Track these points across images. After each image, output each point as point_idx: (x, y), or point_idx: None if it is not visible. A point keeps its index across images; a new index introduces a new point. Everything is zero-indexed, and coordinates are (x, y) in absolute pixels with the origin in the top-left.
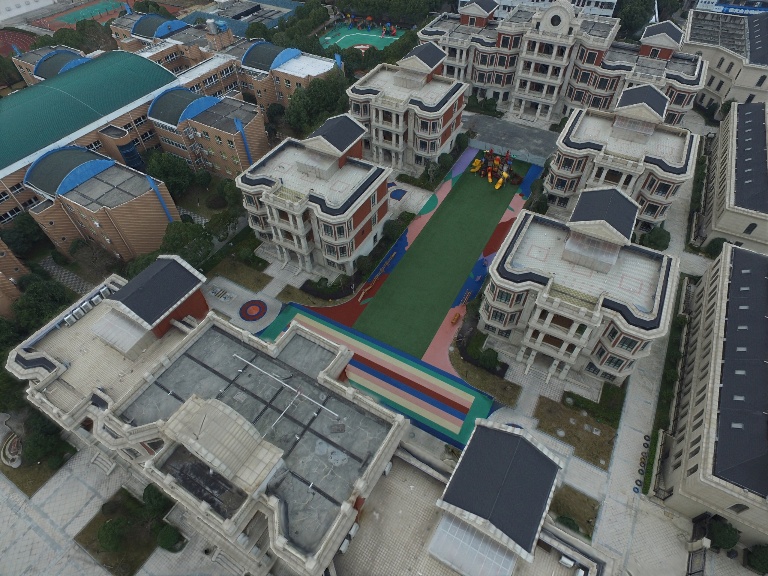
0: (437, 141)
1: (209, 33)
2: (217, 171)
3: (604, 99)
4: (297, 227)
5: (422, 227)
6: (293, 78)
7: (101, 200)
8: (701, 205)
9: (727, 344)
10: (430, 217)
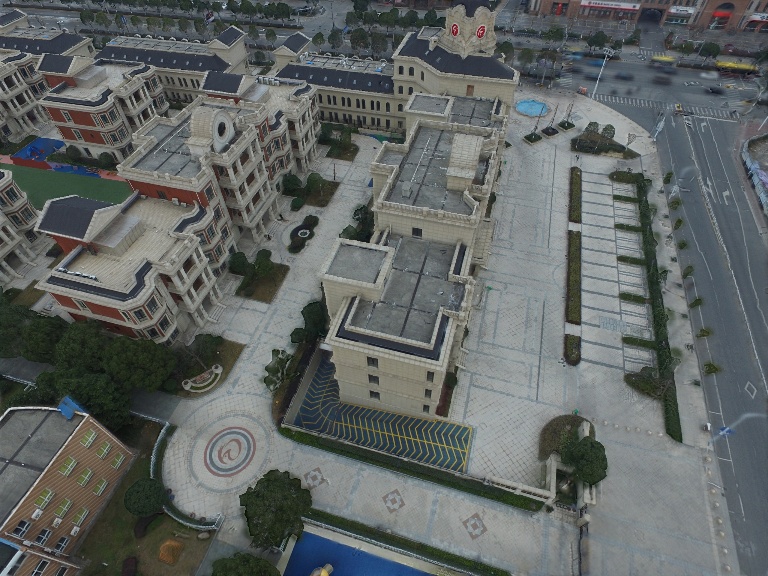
0: None
1: None
2: None
3: None
4: None
5: None
6: None
7: None
8: None
9: (158, 66)
10: None
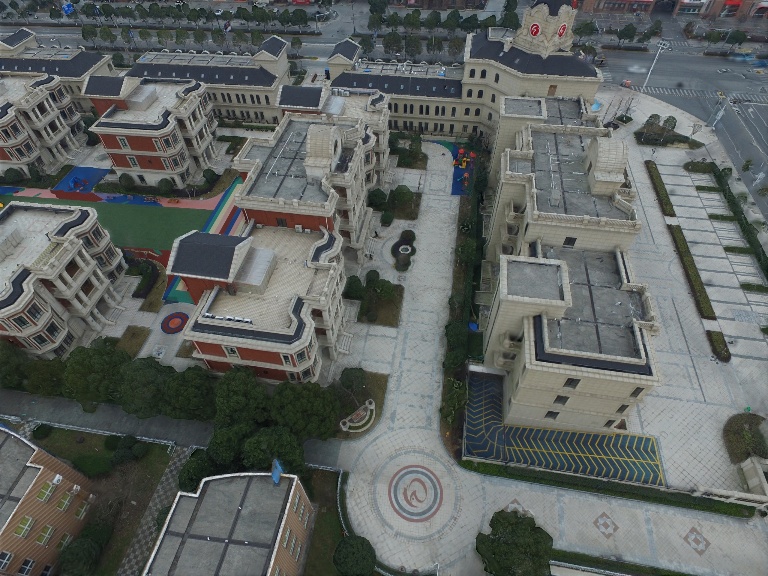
0: None
1: None
2: None
3: None
4: (87, 263)
5: None
6: None
7: (5, 488)
8: None
9: None
10: None
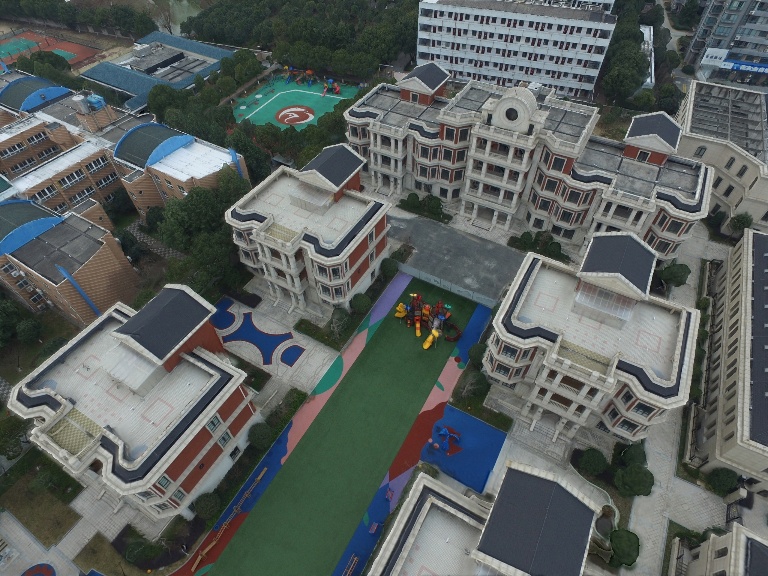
0: (344, 286)
1: (79, 112)
2: (61, 310)
3: (576, 214)
4: None
5: (312, 418)
6: (173, 180)
7: None
8: (701, 392)
9: None
10: (327, 399)
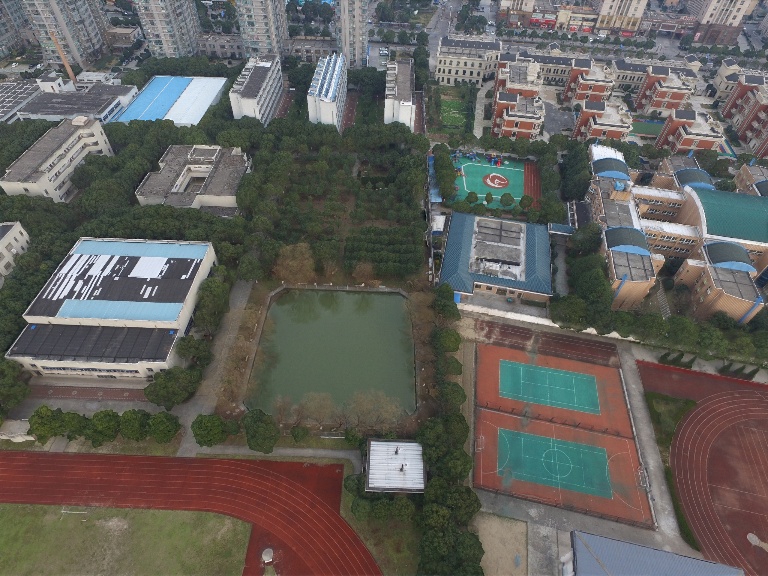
0: None
1: None
2: None
3: None
4: None
5: None
6: None
7: None
8: None
9: None
10: None
